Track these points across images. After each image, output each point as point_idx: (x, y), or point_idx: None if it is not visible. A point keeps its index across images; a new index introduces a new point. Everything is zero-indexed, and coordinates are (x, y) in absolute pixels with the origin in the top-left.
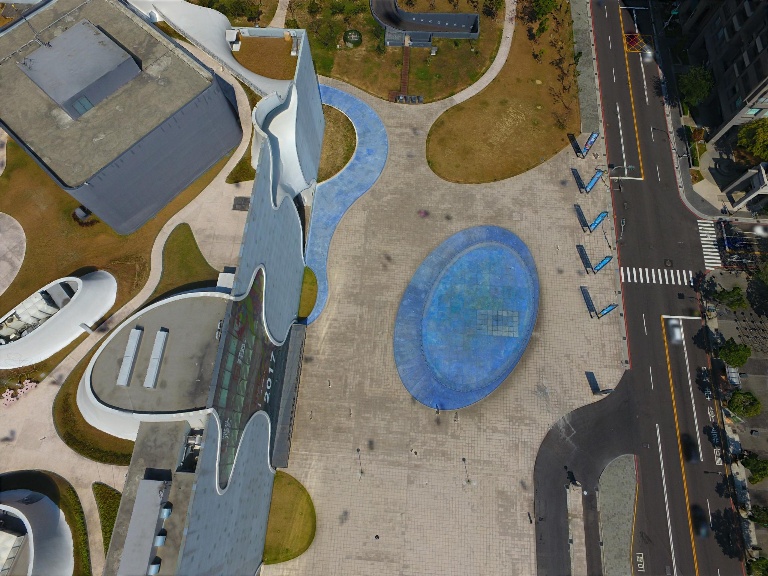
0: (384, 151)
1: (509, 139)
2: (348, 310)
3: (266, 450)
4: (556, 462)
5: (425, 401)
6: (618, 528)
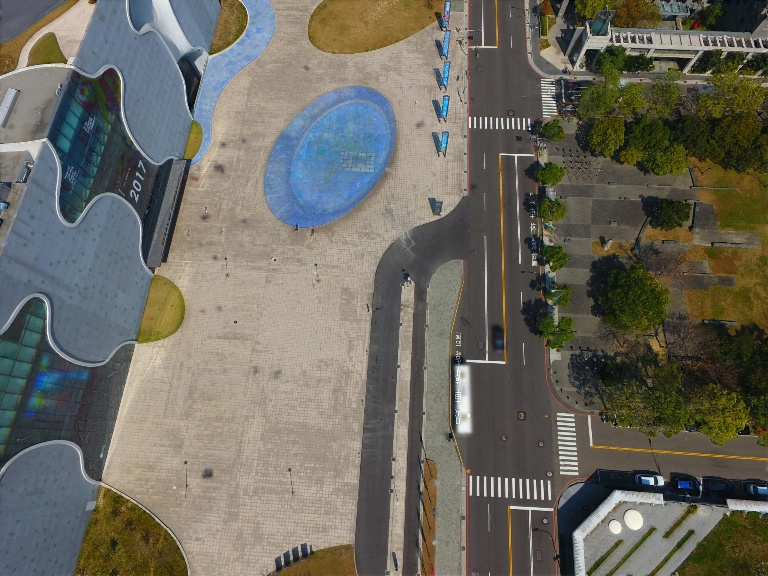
0: (271, 29)
1: (383, 17)
2: (227, 153)
3: (137, 244)
4: (395, 266)
5: (287, 221)
6: (442, 314)
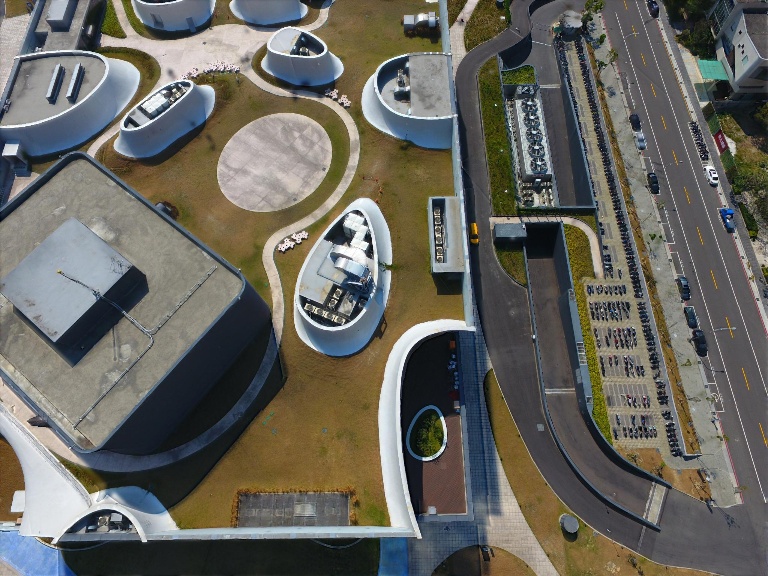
0: None
1: None
2: None
3: None
4: None
5: None
6: None
